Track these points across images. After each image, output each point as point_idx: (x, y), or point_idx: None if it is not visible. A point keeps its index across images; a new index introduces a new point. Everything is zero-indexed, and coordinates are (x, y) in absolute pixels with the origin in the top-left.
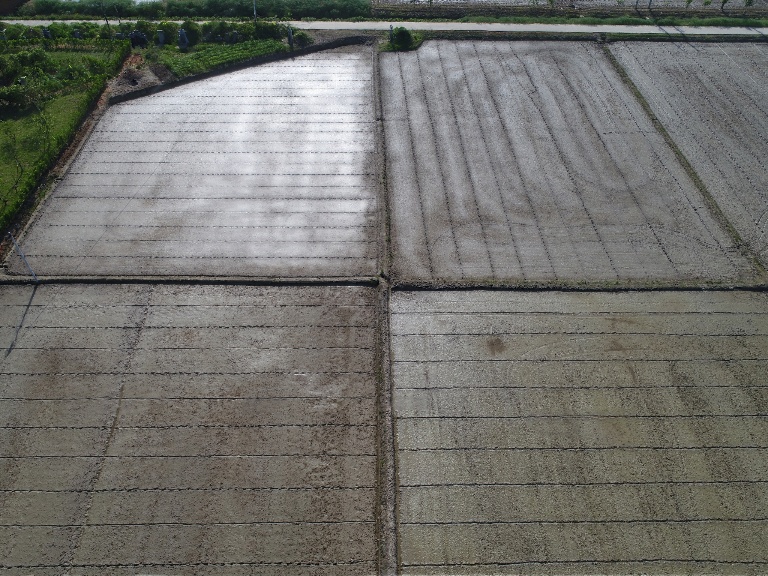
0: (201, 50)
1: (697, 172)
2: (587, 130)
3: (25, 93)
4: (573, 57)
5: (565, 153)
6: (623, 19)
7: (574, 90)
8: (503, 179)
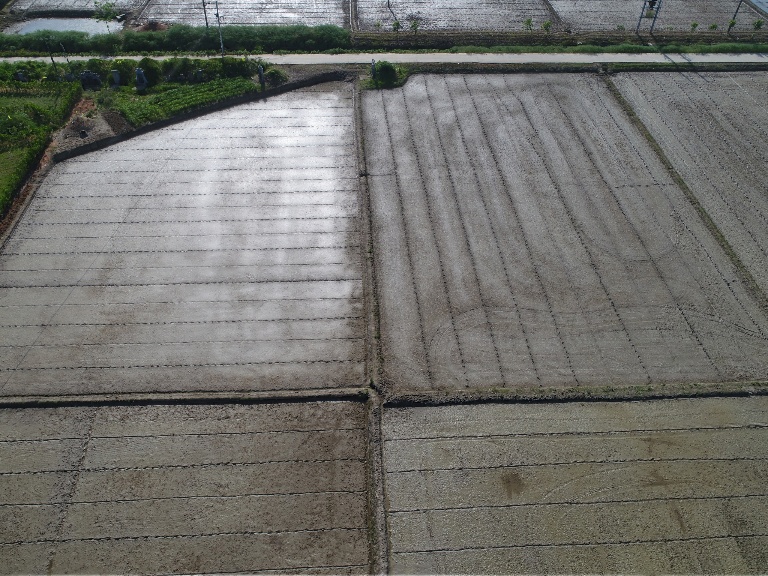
0: (161, 91)
1: (725, 235)
2: (597, 183)
3: None
4: (574, 92)
5: (575, 214)
6: (625, 47)
7: (578, 133)
8: (507, 249)
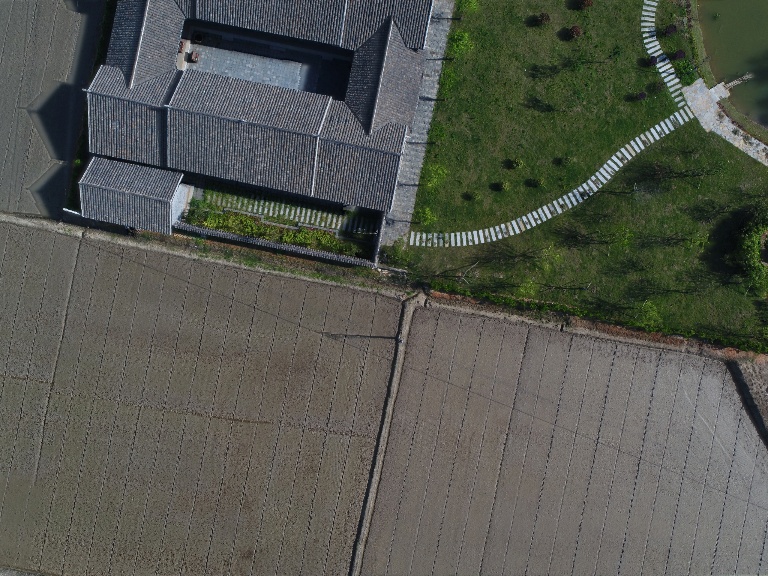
0: None
1: None
2: None
3: (747, 265)
4: None
5: None
6: None
7: None
8: None
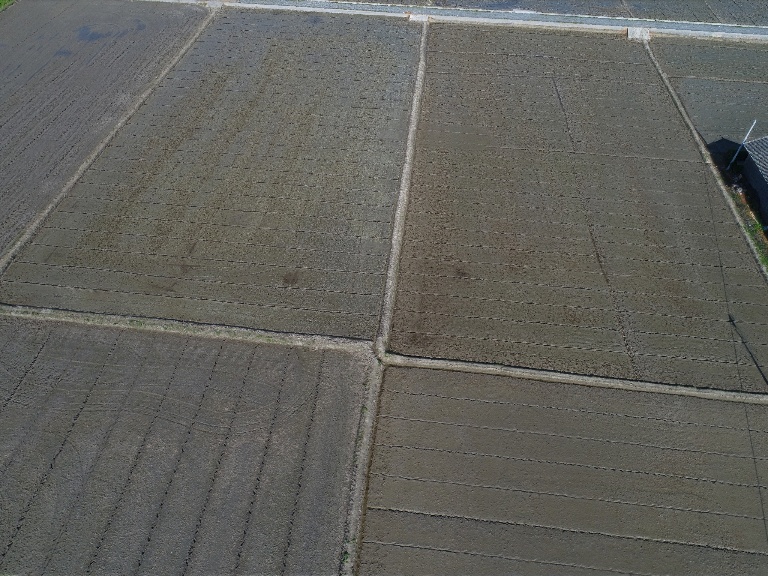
0: None
1: None
2: None
3: None
4: None
5: None
6: None
7: None
8: (140, 531)
